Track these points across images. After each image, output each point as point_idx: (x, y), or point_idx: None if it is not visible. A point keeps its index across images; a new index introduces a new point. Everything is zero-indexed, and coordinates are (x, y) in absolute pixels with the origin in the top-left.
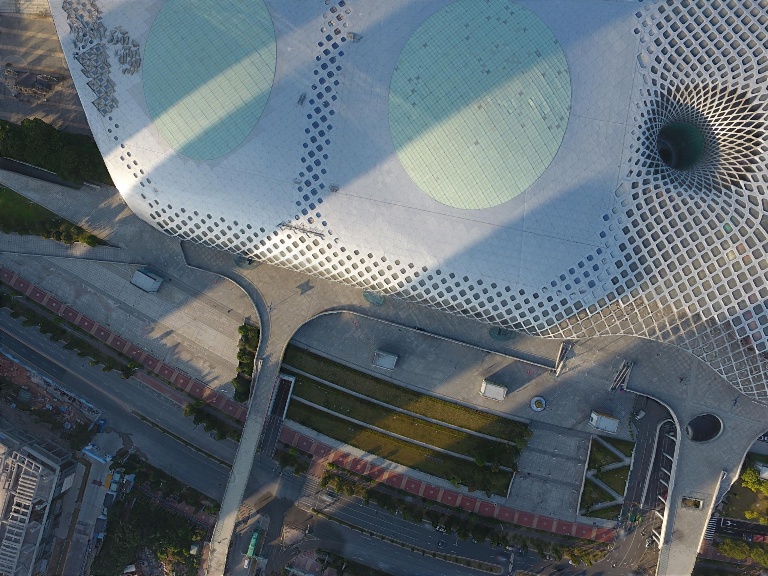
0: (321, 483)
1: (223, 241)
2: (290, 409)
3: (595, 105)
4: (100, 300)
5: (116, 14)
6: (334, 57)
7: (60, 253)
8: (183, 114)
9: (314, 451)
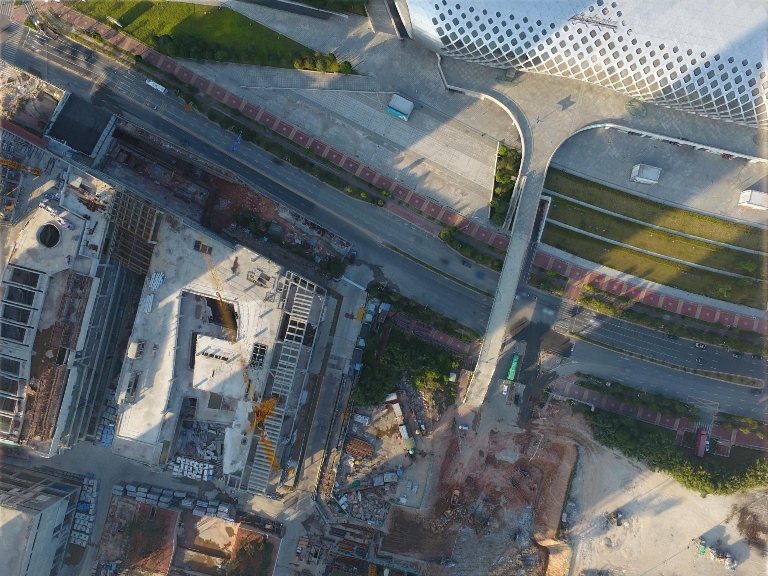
0: (585, 300)
1: (506, 44)
2: (544, 232)
3: None
4: (348, 132)
5: None
6: None
7: (307, 85)
8: None
9: (569, 274)
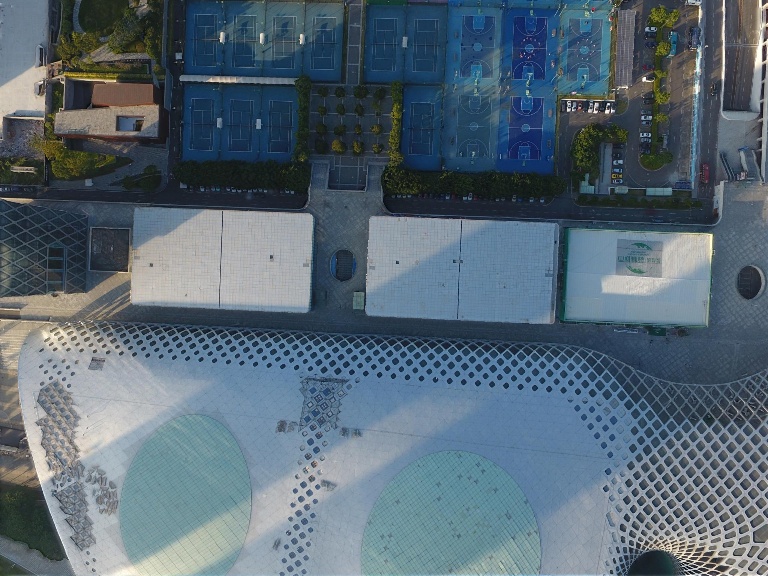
0: None
1: None
2: None
3: (565, 563)
4: None
5: (94, 453)
6: (308, 505)
7: None
8: (159, 556)
9: None
